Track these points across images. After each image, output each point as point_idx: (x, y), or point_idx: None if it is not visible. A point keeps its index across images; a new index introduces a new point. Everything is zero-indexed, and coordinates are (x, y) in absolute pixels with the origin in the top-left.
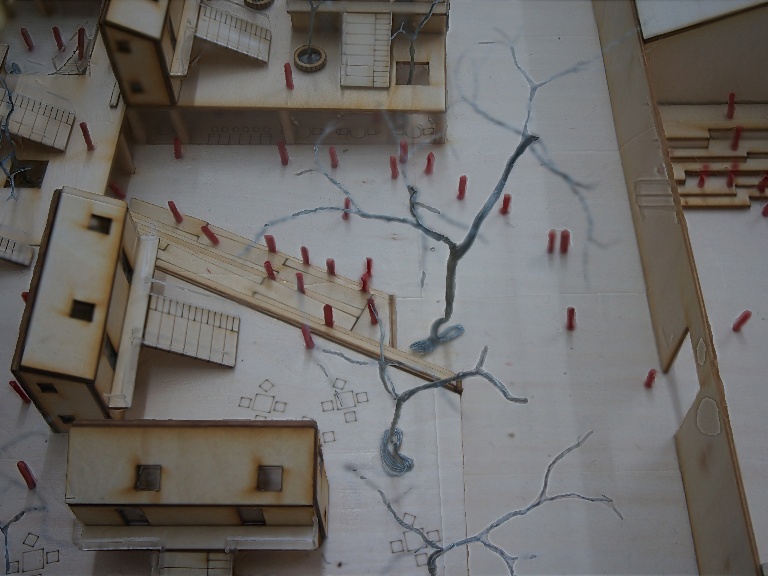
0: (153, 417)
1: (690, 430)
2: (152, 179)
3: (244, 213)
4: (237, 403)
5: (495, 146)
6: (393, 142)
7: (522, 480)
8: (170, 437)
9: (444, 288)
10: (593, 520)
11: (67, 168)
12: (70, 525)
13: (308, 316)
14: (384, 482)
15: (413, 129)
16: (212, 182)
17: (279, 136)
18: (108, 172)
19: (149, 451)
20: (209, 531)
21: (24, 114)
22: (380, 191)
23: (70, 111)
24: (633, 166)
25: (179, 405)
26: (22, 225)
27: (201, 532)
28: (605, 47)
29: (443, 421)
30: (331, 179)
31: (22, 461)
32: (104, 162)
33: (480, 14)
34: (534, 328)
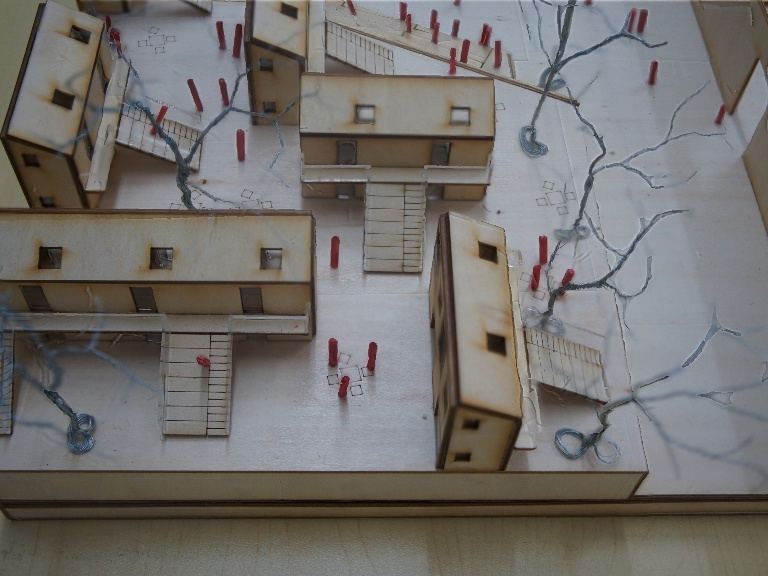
0: None
1: (760, 138)
2: None
3: None
4: None
5: None
6: None
7: (624, 182)
8: (381, 84)
9: None
10: None
11: None
12: (277, 185)
13: None
14: (526, 161)
15: None
16: None
17: None
18: None
19: (365, 94)
20: (403, 171)
21: None
22: None
23: None
24: None
25: None
26: None
27: (397, 171)
28: None
29: (567, 123)
30: None
31: None
32: None
33: None
34: (622, 83)
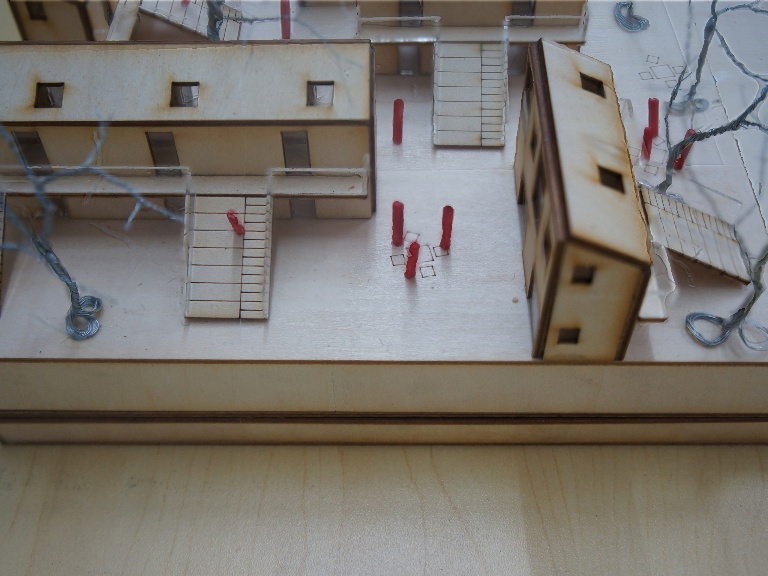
0: None
1: None
2: None
3: None
4: None
5: None
6: None
7: (739, 74)
8: None
9: None
10: None
11: None
12: None
13: None
14: (623, 36)
15: None
16: None
17: None
18: None
19: None
20: (479, 29)
21: None
22: None
23: None
24: None
25: None
26: None
27: (472, 30)
28: None
29: None
30: None
31: None
32: None
33: None
34: None
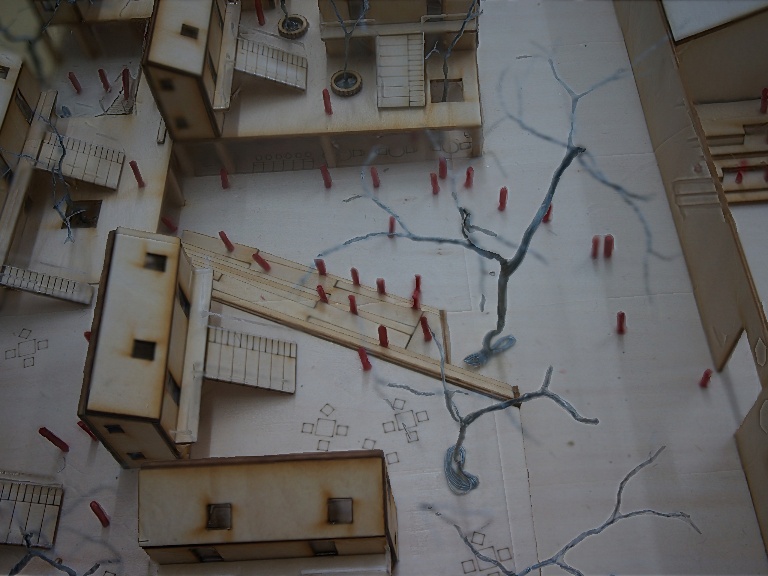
0: (219, 448)
1: (752, 430)
2: (202, 210)
3: (292, 237)
4: (300, 429)
5: (531, 156)
6: (432, 158)
7: (585, 488)
8: (238, 475)
9: (492, 299)
10: (660, 525)
11: (120, 206)
12: (145, 561)
13: (363, 337)
14: (451, 501)
15: (450, 144)
16: (259, 209)
17: (321, 160)
18: (160, 207)
19: (218, 490)
20: (282, 564)
21: (76, 156)
22: (422, 207)
23: (120, 150)
24: (670, 166)
25: (243, 434)
26: (81, 264)
27: (274, 565)
28: (632, 51)
29: (504, 436)
30: (380, 204)
31: (94, 501)
32: (155, 198)
33: (506, 27)
34: (585, 334)
